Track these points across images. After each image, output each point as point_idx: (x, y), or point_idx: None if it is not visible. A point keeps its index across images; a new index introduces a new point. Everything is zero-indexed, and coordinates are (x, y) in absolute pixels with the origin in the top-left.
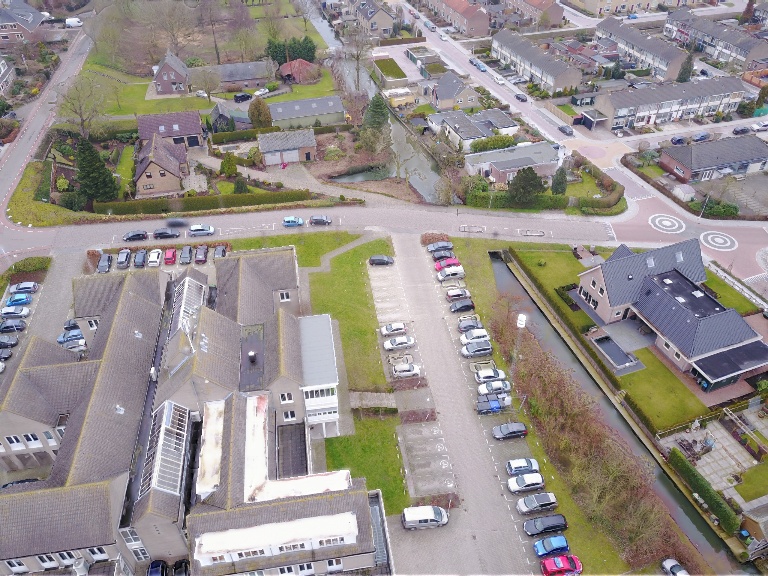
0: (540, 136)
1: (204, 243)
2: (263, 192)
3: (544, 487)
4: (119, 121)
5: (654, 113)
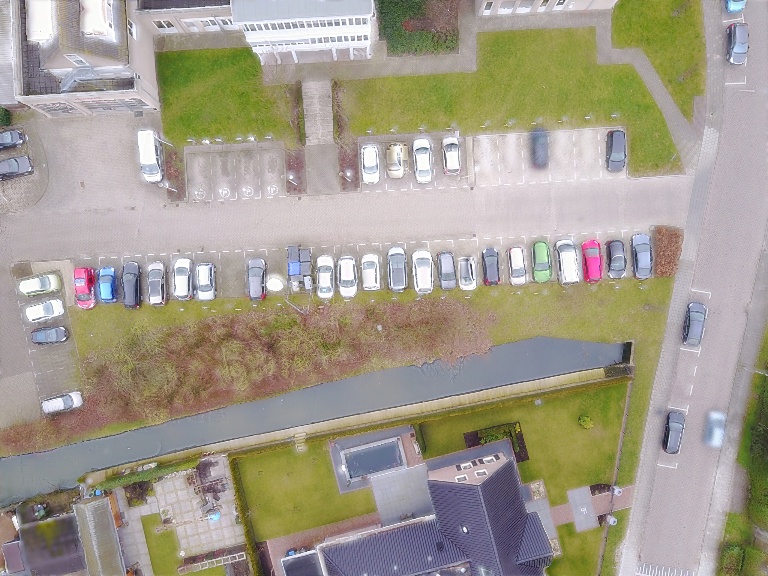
0: None
1: None
2: None
3: None
4: None
5: None
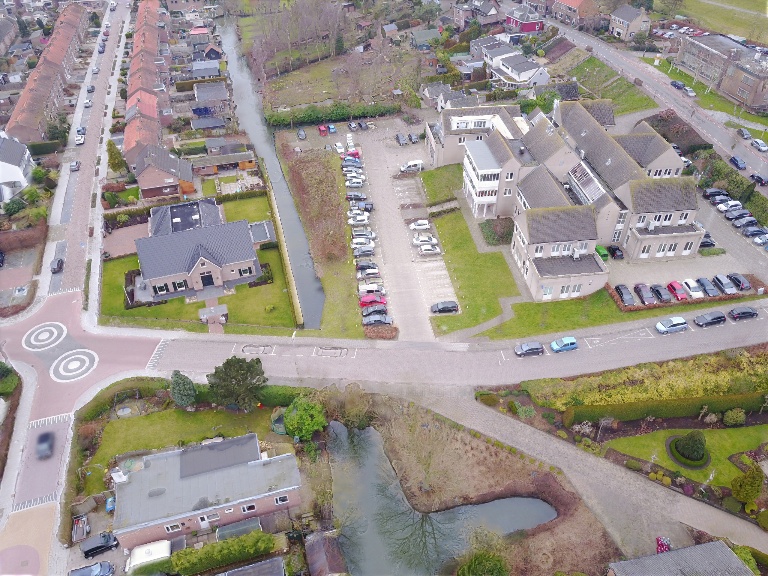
0: None
1: (652, 304)
2: None
3: None
4: None
5: None
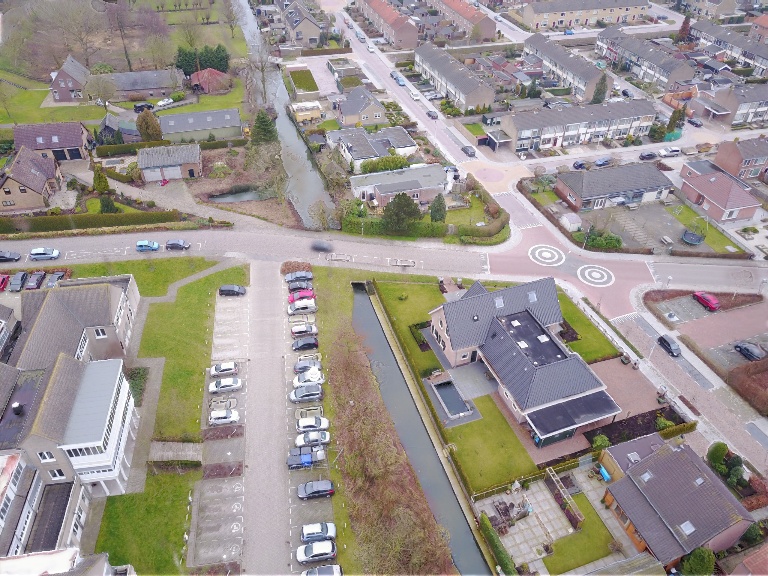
0: (440, 157)
1: (41, 269)
2: (133, 211)
3: (335, 557)
4: (0, 130)
5: (560, 135)
